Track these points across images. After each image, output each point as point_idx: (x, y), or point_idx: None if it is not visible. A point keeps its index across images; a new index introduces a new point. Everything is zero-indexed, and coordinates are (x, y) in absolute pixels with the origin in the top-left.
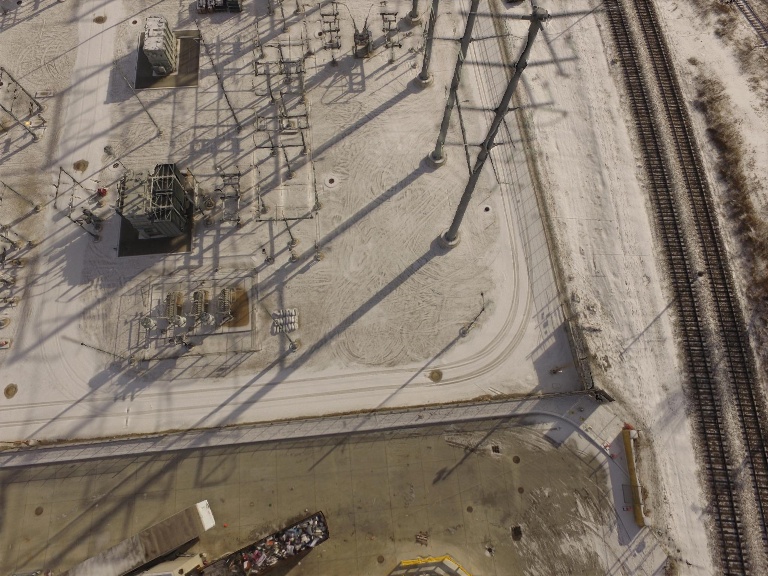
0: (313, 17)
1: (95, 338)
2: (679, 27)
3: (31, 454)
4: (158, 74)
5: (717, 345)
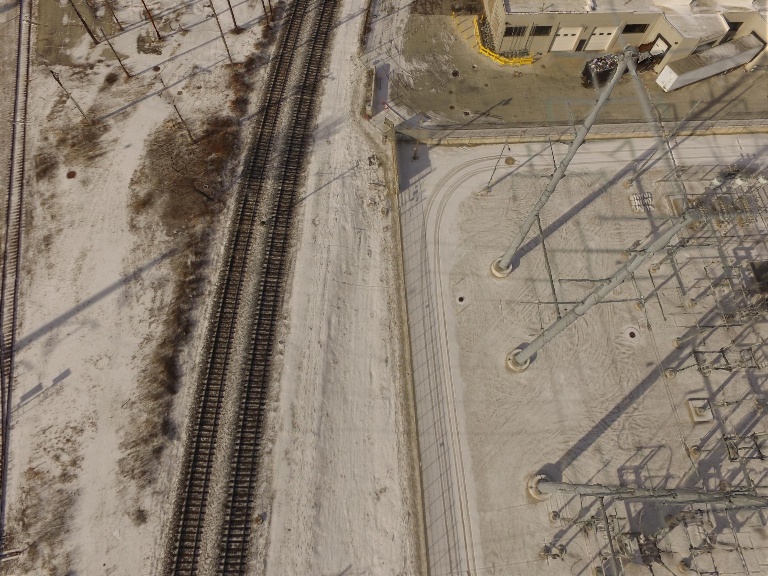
0: None
1: None
2: None
3: None
4: None
5: (272, 169)
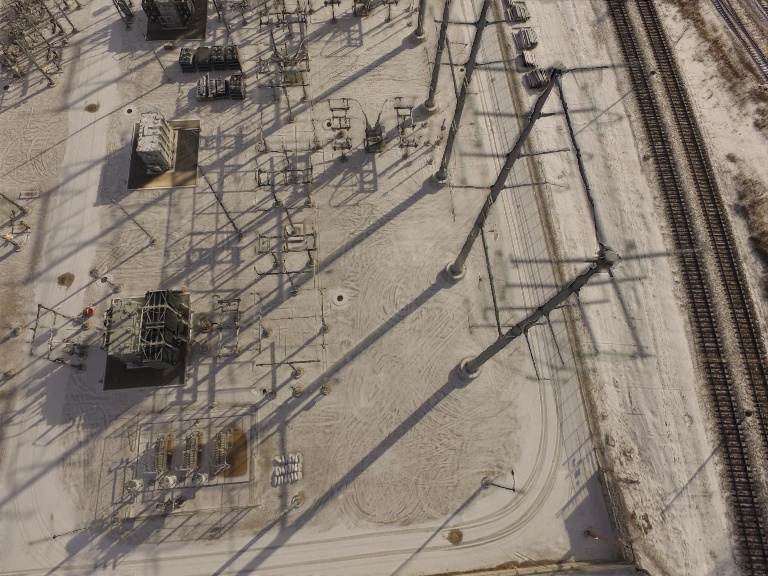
0: (321, 105)
1: (75, 490)
2: (715, 117)
3: None
4: (153, 172)
5: None
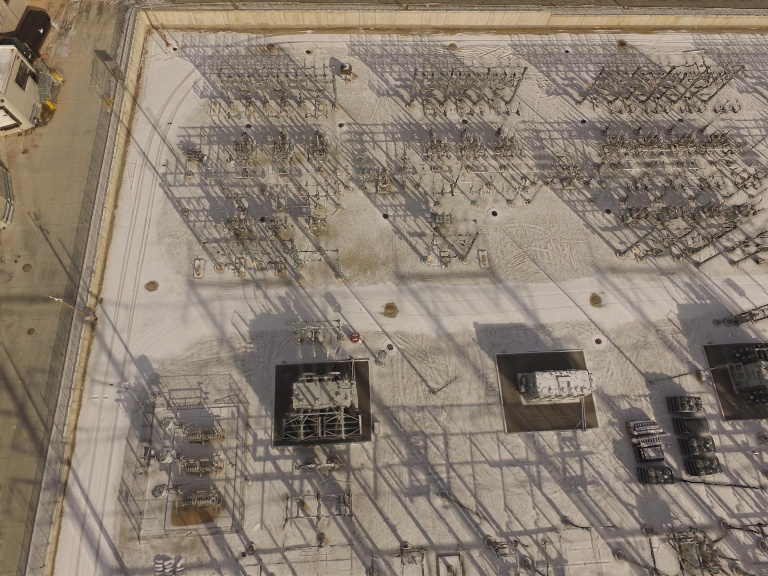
0: None
1: (188, 354)
2: None
3: (82, 317)
4: (521, 380)
5: None
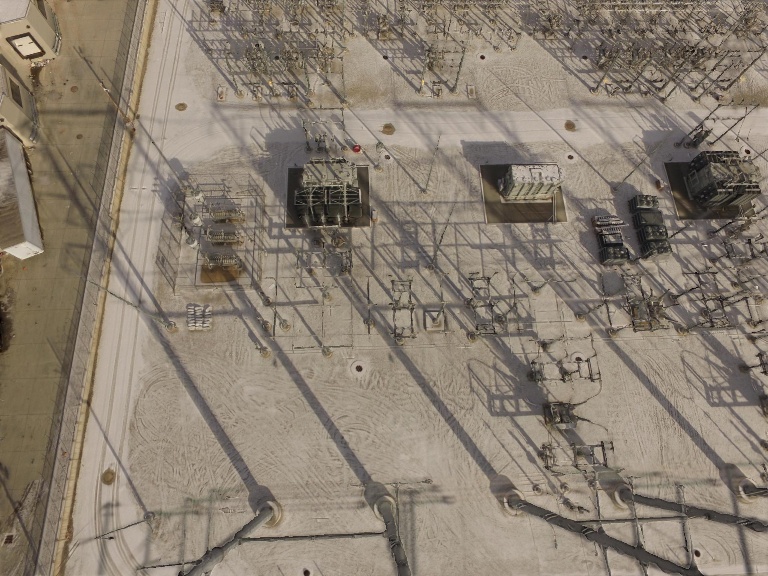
0: (606, 351)
1: (213, 158)
2: None
3: (123, 126)
4: None
5: None
